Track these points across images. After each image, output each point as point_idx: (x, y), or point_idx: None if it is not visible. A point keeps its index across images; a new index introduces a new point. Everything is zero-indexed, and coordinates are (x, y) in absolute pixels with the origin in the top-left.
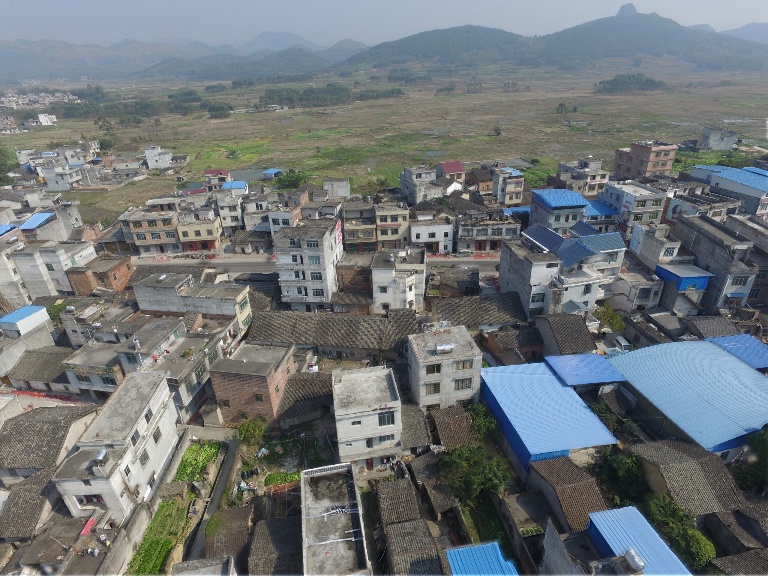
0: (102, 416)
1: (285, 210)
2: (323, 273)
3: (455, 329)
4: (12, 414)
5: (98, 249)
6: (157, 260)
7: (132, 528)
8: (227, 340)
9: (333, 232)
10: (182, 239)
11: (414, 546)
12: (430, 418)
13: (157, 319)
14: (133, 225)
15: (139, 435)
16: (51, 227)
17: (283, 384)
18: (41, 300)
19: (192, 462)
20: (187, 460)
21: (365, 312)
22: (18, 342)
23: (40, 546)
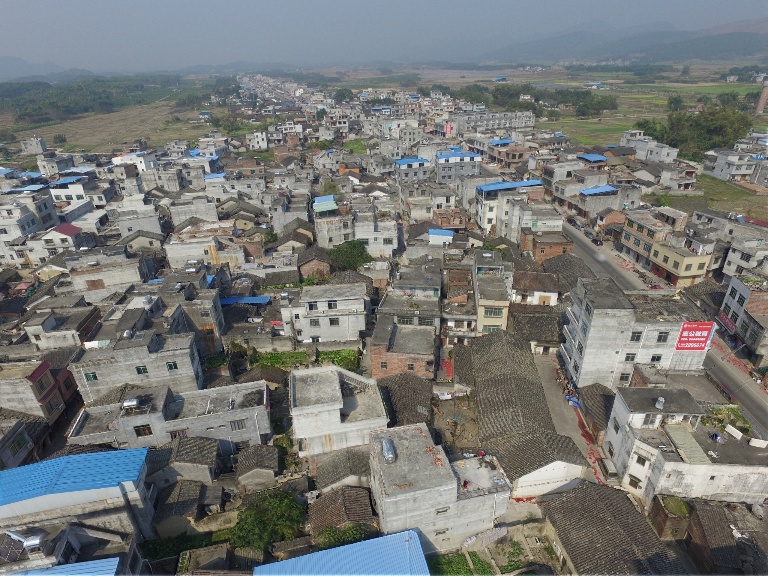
0: (324, 287)
1: (765, 287)
2: (584, 349)
3: (445, 470)
4: (381, 277)
5: (608, 232)
6: (622, 264)
7: (277, 340)
8: (462, 327)
9: (659, 323)
10: (651, 257)
11: (184, 449)
12: (347, 485)
13: (439, 275)
14: (628, 223)
15: (317, 308)
16: (604, 200)
17: (398, 370)
18: (499, 239)
19: (338, 355)
20: (340, 352)
21: (596, 434)
22: (425, 246)
23: (272, 315)
